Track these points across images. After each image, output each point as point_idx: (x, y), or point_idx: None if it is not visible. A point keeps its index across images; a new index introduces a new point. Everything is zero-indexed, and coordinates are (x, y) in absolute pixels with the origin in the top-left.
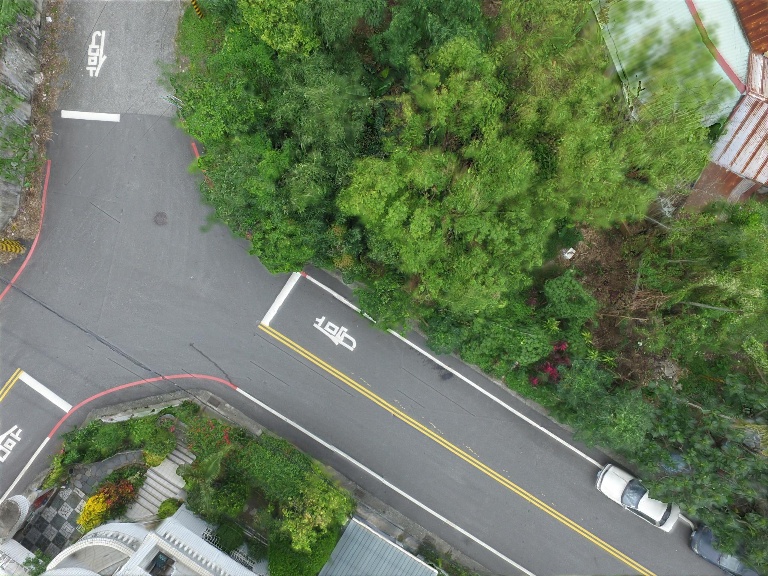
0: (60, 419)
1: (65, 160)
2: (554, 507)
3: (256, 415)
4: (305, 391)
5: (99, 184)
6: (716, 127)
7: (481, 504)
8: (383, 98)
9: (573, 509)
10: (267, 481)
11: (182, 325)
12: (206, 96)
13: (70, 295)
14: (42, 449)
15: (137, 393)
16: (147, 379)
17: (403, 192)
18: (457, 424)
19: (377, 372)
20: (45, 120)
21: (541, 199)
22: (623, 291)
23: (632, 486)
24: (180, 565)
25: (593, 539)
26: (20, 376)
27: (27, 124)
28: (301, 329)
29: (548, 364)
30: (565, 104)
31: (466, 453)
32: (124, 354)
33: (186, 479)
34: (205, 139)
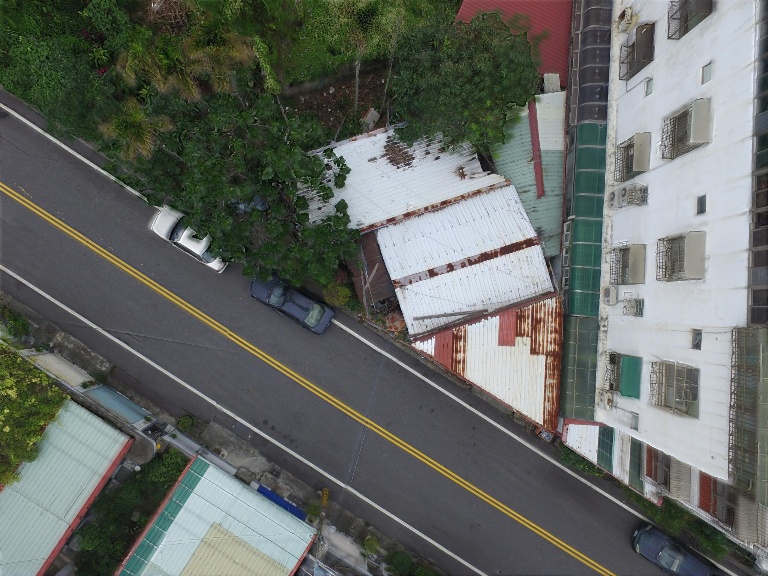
0: None
1: None
2: (111, 251)
3: None
4: None
5: None
6: None
7: (33, 247)
8: None
9: (133, 254)
10: None
11: None
12: None
13: None
14: None
15: None
16: None
17: None
18: (10, 163)
19: None
20: None
21: None
22: None
23: (181, 223)
24: None
25: (152, 285)
26: None
27: None
28: None
29: None
30: None
31: (18, 193)
32: None
33: None
34: None
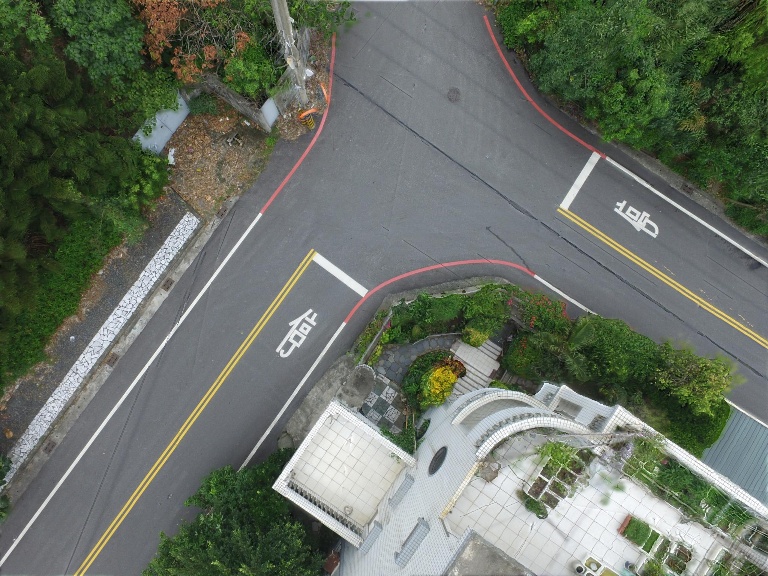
0: (356, 303)
1: (352, 32)
2: None
3: None
4: (606, 280)
5: (390, 57)
6: None
7: None
8: None
9: None
10: None
11: (478, 207)
12: None
13: (363, 173)
14: (339, 334)
15: (433, 278)
16: (443, 263)
17: None
18: (767, 317)
19: (681, 260)
20: None
21: None
22: None
23: None
24: None
25: None
26: (314, 257)
27: None
28: (601, 214)
29: None
30: None
31: None
32: None
33: None
34: None
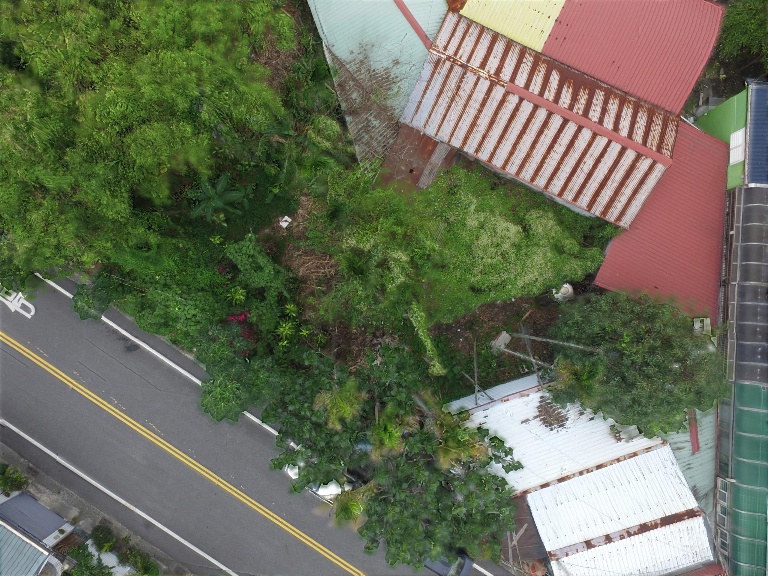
0: None
1: None
2: (242, 490)
3: None
4: None
5: None
6: (321, 71)
7: (164, 486)
8: None
9: (264, 493)
10: None
11: None
12: None
13: None
14: None
15: None
16: None
17: None
18: (141, 399)
19: (56, 342)
20: None
21: (252, 163)
22: None
23: None
24: None
25: (284, 525)
26: None
27: None
28: None
29: None
30: (291, 66)
31: (149, 430)
32: None
33: None
34: None
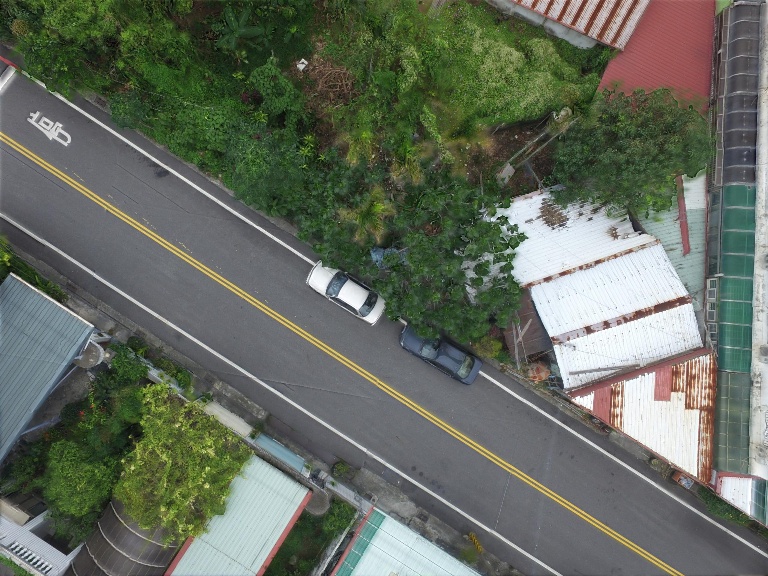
0: None
1: None
2: (267, 304)
3: None
4: (17, 185)
5: None
6: None
7: (193, 300)
8: None
9: (287, 307)
10: None
11: None
12: None
13: None
14: None
15: None
16: None
17: None
18: (171, 221)
19: (91, 168)
20: None
21: (270, 8)
22: None
23: (337, 278)
24: None
25: (305, 336)
26: None
27: None
28: (14, 123)
29: None
30: None
31: (179, 249)
32: None
33: None
34: None
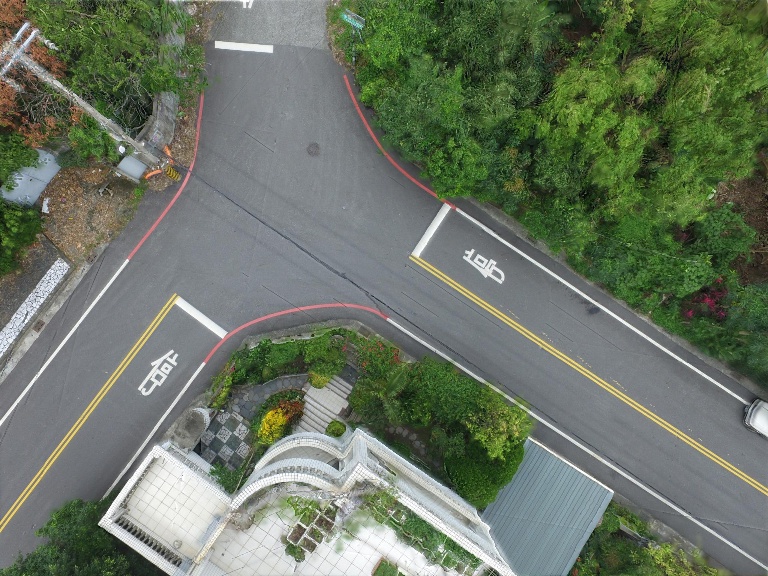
0: (216, 345)
1: (219, 90)
2: (701, 442)
3: (406, 346)
4: (454, 323)
5: (253, 114)
6: None
7: (628, 438)
8: (541, 30)
9: (719, 445)
10: (441, 400)
11: (334, 255)
12: (388, 15)
13: (225, 222)
14: (198, 374)
15: (290, 321)
16: (300, 307)
17: (610, 100)
18: (604, 358)
19: (525, 305)
20: (198, 50)
21: None
22: (762, 232)
23: None
24: (390, 465)
25: (739, 475)
26: (177, 301)
27: (182, 54)
28: (451, 261)
29: (705, 295)
30: None
31: (614, 387)
32: (322, 262)
33: (355, 400)
34: (381, 61)
